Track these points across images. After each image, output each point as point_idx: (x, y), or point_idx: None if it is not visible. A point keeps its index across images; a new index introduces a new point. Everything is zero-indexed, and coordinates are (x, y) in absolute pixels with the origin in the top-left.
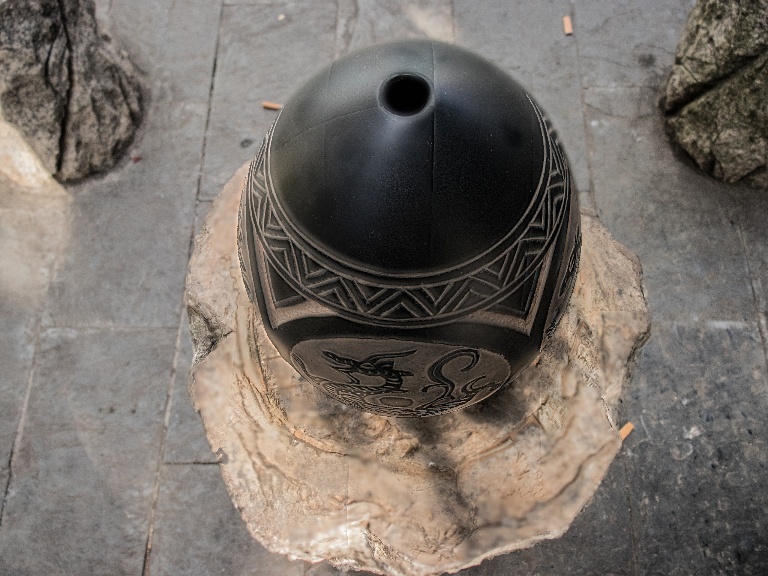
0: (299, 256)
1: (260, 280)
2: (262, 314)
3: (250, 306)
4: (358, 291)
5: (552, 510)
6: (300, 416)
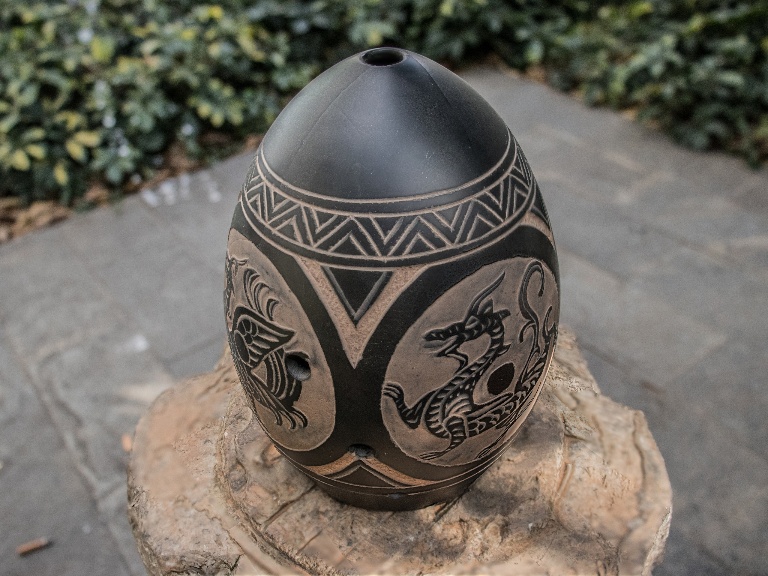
0: (369, 226)
1: (325, 309)
2: (334, 365)
3: (241, 521)
4: (439, 221)
5: (653, 489)
6: (377, 575)
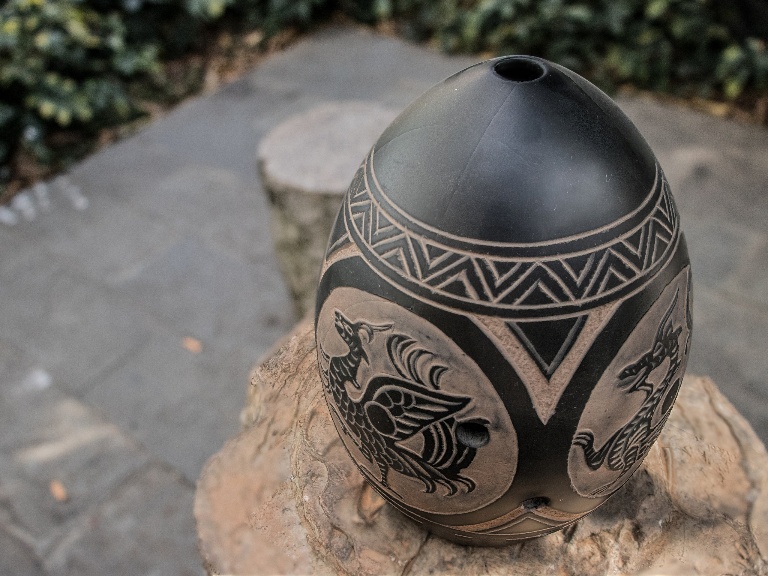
0: (559, 269)
1: (513, 368)
2: (521, 426)
3: None
4: (628, 250)
5: (753, 456)
6: None
